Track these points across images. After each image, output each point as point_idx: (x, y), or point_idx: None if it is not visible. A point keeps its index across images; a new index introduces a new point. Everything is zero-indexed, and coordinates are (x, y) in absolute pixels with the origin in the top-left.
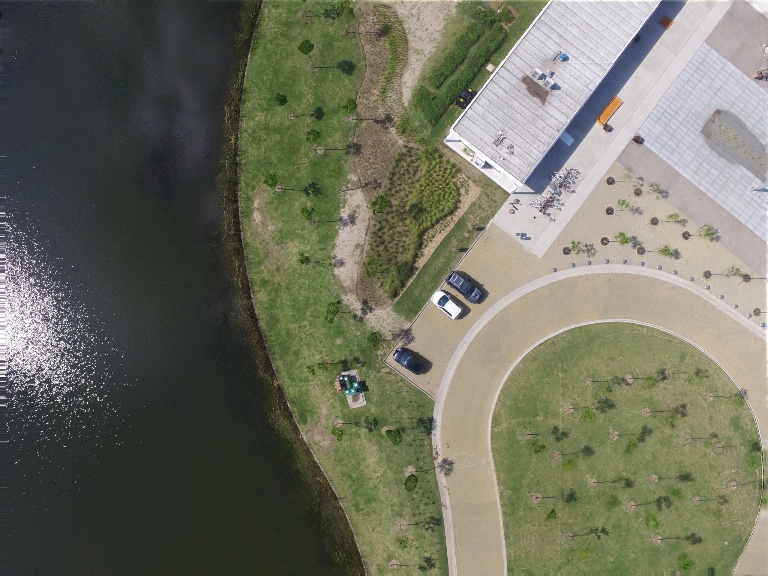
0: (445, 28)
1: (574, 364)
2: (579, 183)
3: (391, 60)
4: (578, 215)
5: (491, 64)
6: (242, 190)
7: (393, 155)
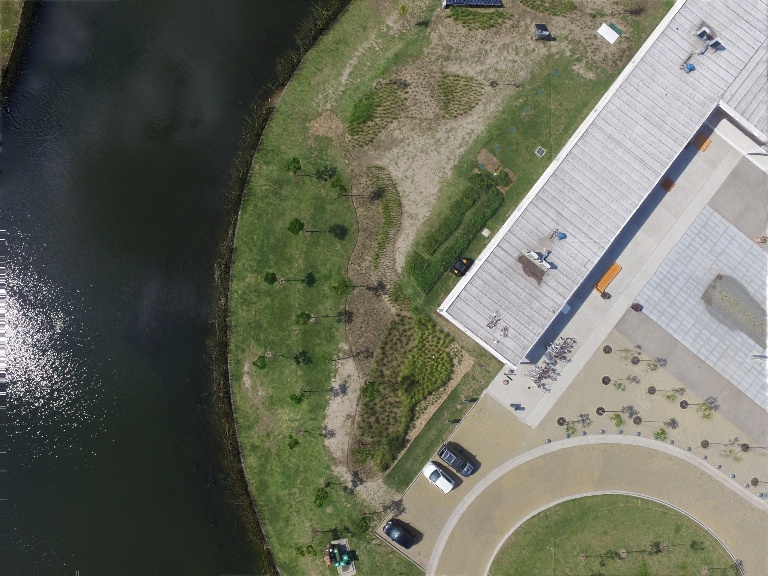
0: (440, 191)
1: (567, 539)
2: (575, 352)
3: (384, 225)
4: (574, 385)
5: (487, 229)
6: (232, 352)
7: (385, 323)
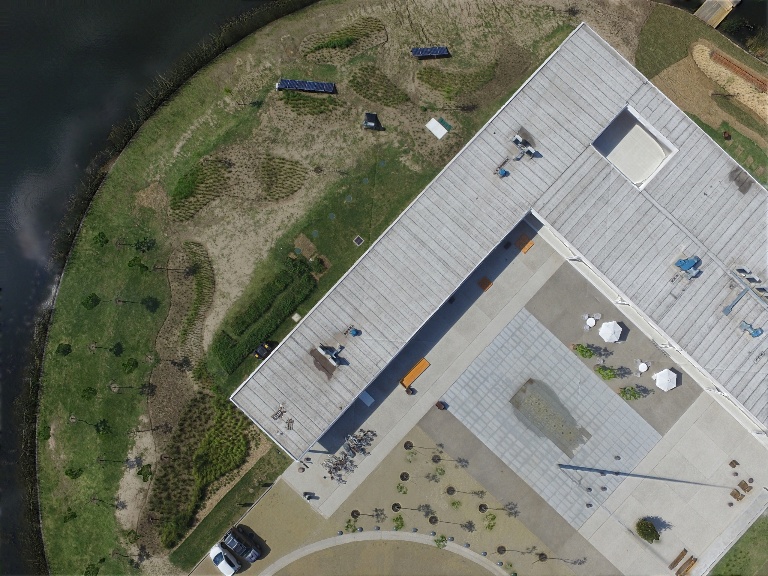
0: (254, 272)
1: None
2: (375, 445)
3: (196, 301)
4: (371, 478)
5: (297, 314)
6: (41, 412)
7: (187, 400)
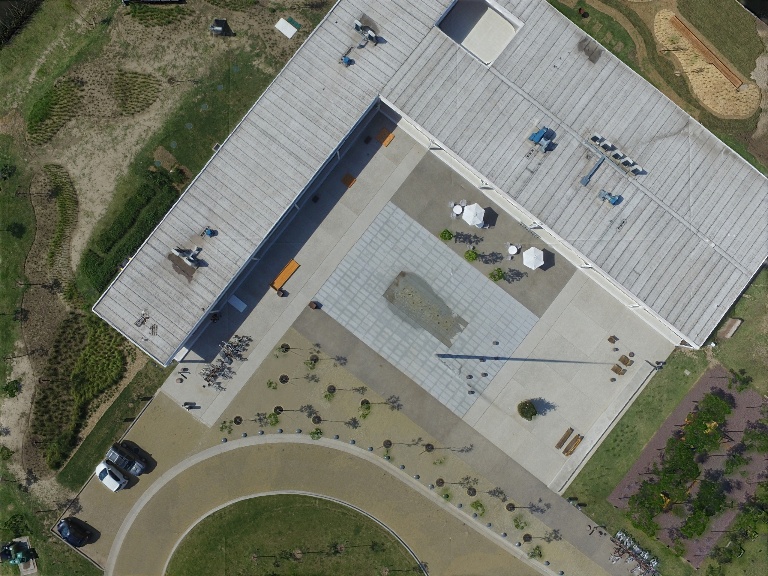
0: (116, 189)
1: (238, 539)
2: (251, 350)
3: (60, 223)
4: (250, 383)
5: None
6: None
7: (60, 322)
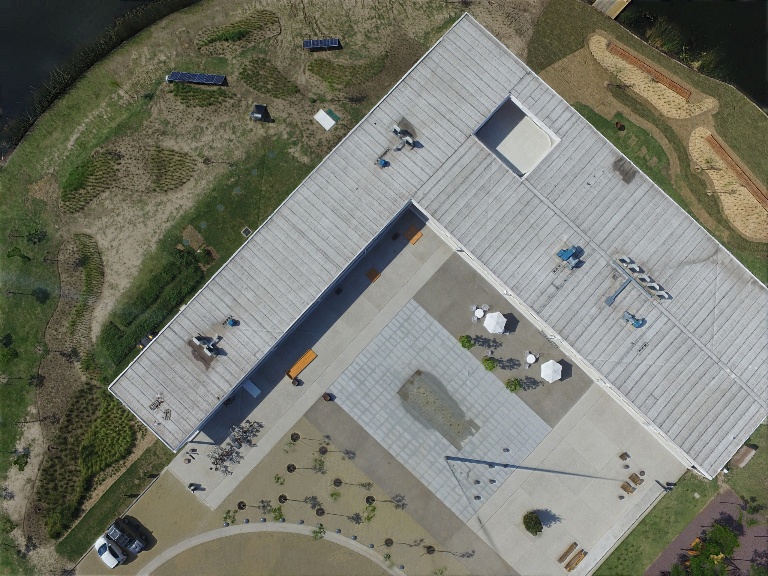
0: (143, 264)
1: None
2: (261, 437)
3: (84, 292)
4: (257, 470)
5: (185, 305)
6: None
7: (75, 391)
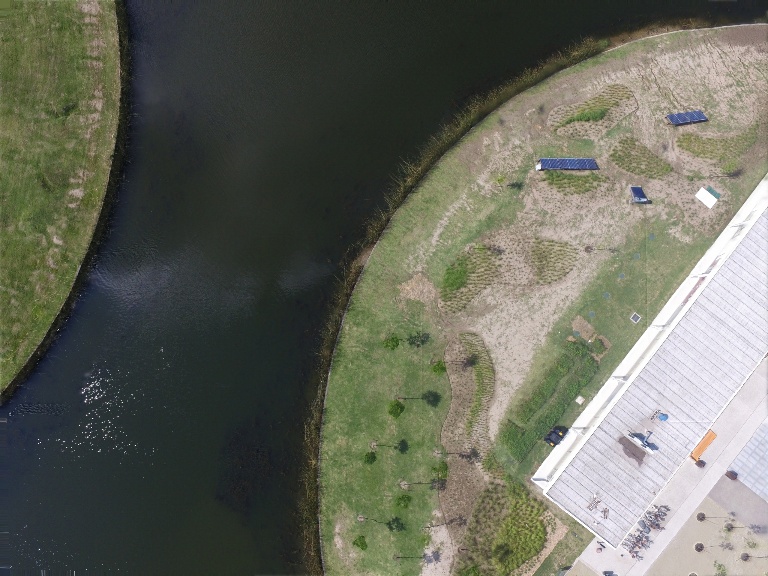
0: (534, 358)
1: None
2: (668, 520)
3: (477, 392)
4: (666, 552)
5: (581, 396)
6: (322, 513)
7: (478, 491)
